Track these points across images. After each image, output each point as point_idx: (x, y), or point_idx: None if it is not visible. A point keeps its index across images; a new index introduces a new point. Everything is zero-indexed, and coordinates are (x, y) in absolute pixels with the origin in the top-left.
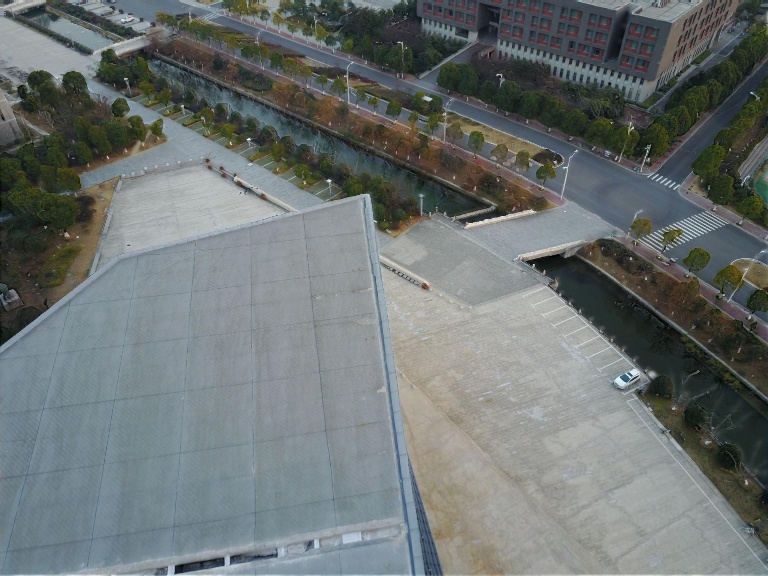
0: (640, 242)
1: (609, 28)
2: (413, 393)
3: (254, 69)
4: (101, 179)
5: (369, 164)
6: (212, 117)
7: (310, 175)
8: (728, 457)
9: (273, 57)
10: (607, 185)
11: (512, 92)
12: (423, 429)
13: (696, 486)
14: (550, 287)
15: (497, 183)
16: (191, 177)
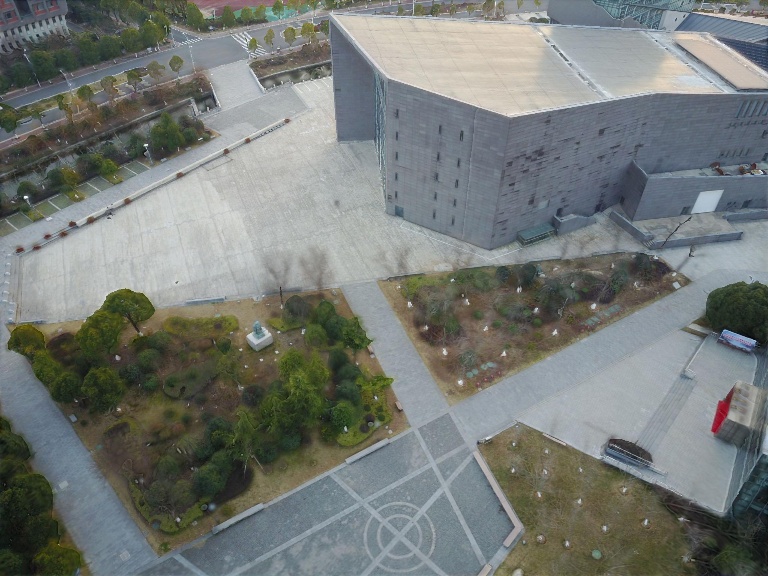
0: None
1: None
2: None
3: None
4: (5, 342)
5: None
6: None
7: (97, 179)
8: None
9: None
10: (187, 57)
11: (47, 57)
12: None
13: None
14: (295, 83)
15: None
16: (50, 261)
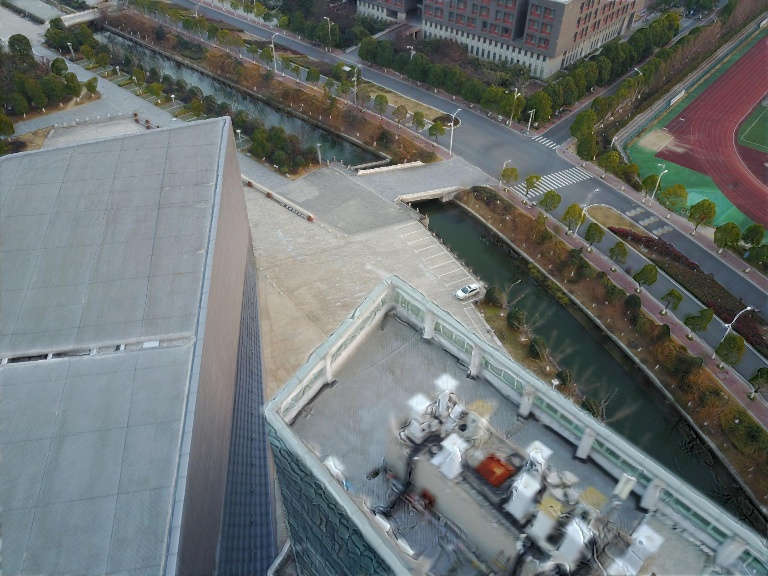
0: (511, 190)
1: (514, 9)
2: (280, 298)
3: (194, 40)
4: (35, 128)
5: (289, 125)
6: (143, 77)
7: None
8: (533, 347)
9: (210, 29)
10: (494, 144)
11: (421, 63)
12: (282, 324)
13: None
14: (420, 222)
15: (395, 140)
16: (118, 128)
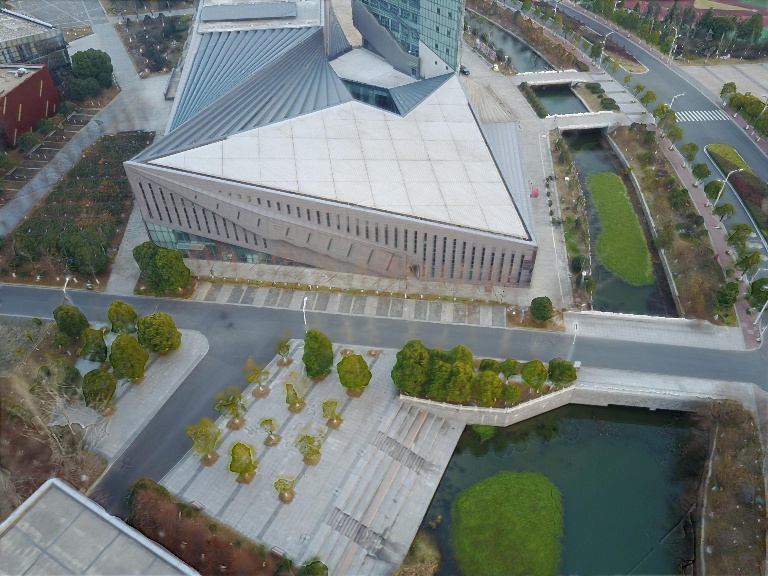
0: None
1: None
2: (344, 14)
3: None
4: None
5: None
6: None
7: None
8: None
9: None
10: None
11: None
12: (345, 20)
13: None
14: None
15: None
16: None
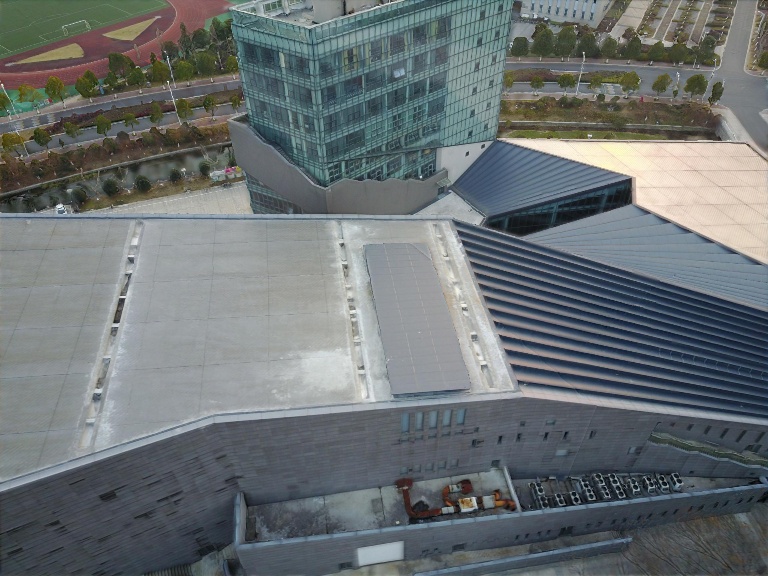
0: None
1: None
2: None
3: None
4: None
5: None
6: None
7: None
8: (144, 182)
9: None
10: None
11: None
12: None
13: (154, 204)
14: None
15: None
16: None
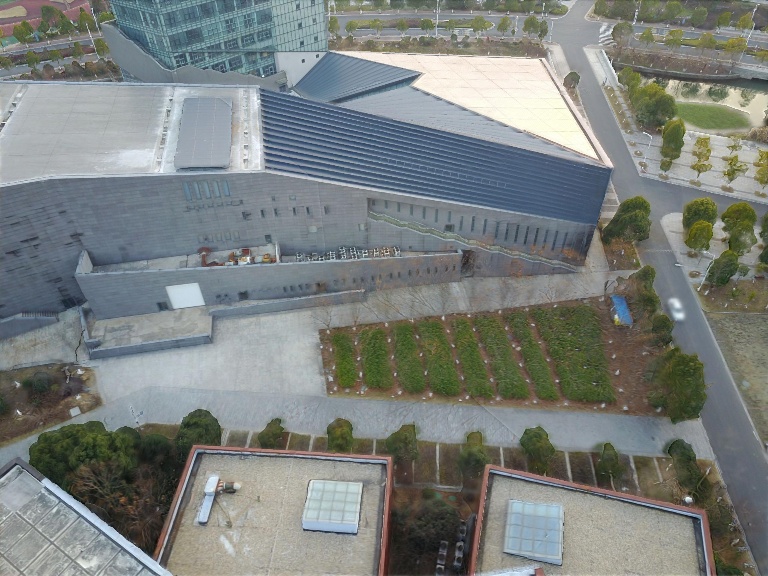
0: None
1: None
2: None
3: None
4: None
5: None
6: None
7: None
8: None
9: None
10: None
11: None
12: None
13: None
14: None
15: None
16: None
